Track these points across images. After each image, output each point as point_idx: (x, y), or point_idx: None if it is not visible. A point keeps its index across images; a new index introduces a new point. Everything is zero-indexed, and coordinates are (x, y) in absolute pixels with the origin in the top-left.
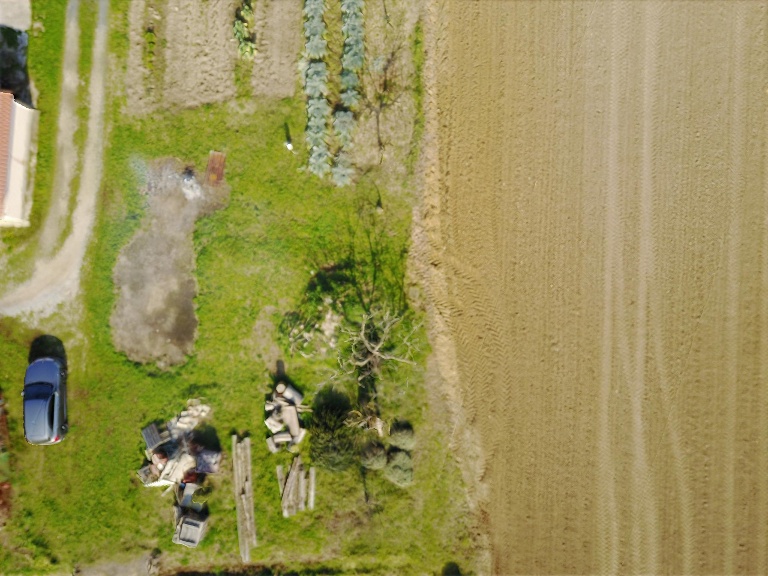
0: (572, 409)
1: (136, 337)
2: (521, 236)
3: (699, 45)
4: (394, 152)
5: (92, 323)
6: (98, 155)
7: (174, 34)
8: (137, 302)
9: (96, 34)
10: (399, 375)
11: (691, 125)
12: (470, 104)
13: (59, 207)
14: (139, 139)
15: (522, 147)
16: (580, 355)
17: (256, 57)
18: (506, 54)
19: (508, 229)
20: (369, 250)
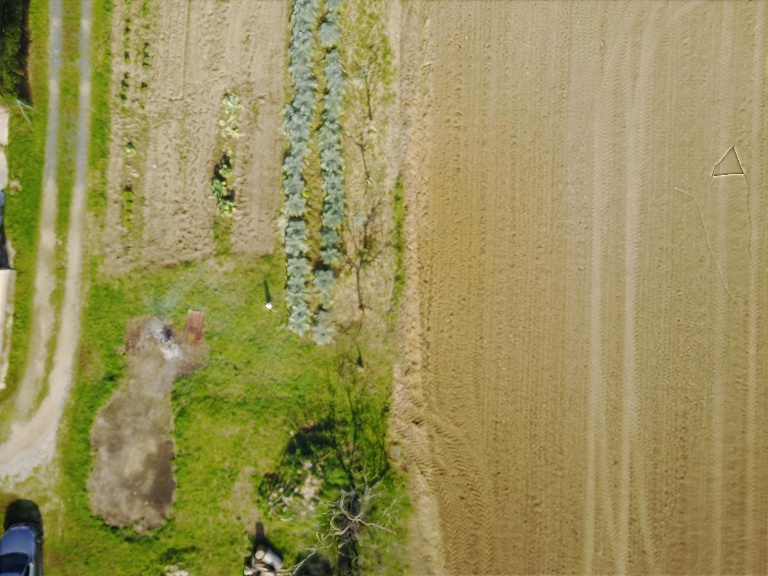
0: (555, 571)
1: (113, 500)
2: (503, 394)
3: (680, 202)
4: (374, 309)
5: (68, 487)
6: (75, 315)
7: (152, 192)
8: (114, 464)
9: (73, 193)
10: (380, 536)
11: (673, 284)
12: (451, 260)
13: (35, 368)
14: (116, 298)
15: (503, 304)
16: (563, 516)
17: (235, 214)
18: (487, 210)
19: (489, 387)
20: (349, 409)
